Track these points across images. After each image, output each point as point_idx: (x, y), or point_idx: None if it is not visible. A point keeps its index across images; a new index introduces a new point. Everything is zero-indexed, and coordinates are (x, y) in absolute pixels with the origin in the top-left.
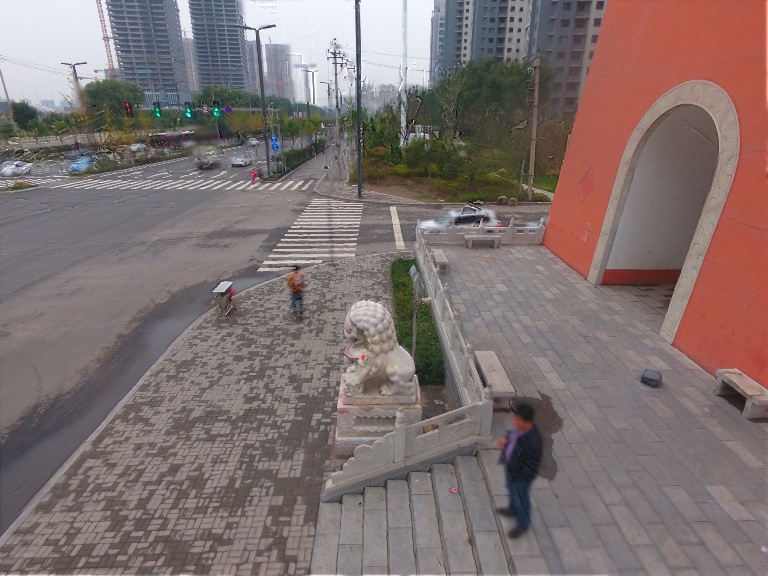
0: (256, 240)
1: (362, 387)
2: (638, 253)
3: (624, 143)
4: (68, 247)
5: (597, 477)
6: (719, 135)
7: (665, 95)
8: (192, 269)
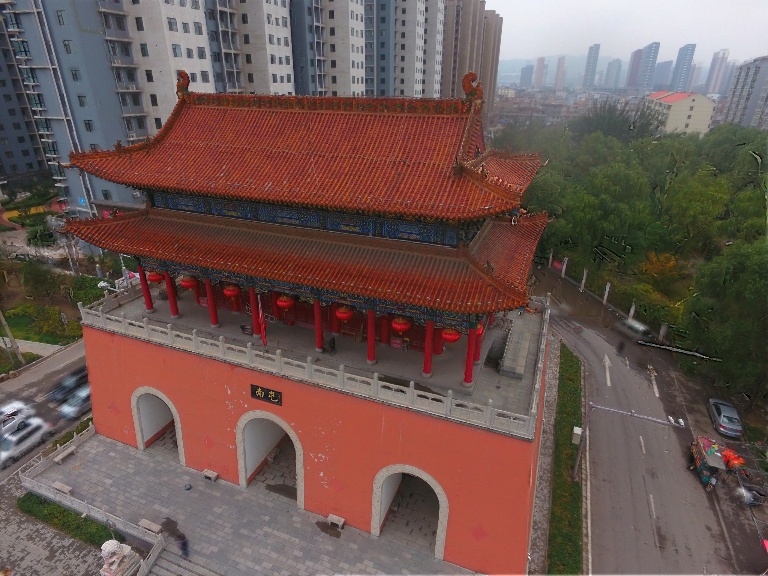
0: None
1: (118, 566)
2: (153, 429)
3: (129, 398)
4: None
5: (193, 529)
6: (169, 407)
7: (141, 388)
8: None
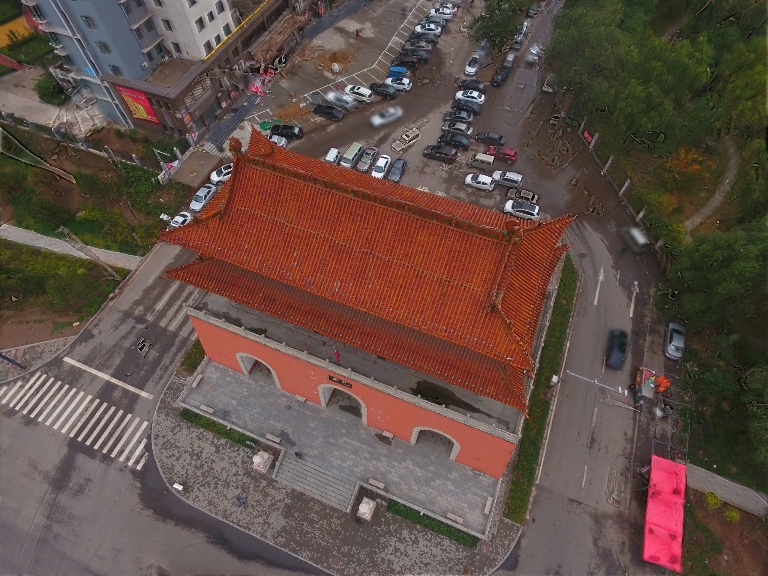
0: (88, 462)
1: (263, 465)
2: None
3: None
4: (26, 570)
5: (300, 438)
6: (267, 366)
7: None
8: (117, 499)
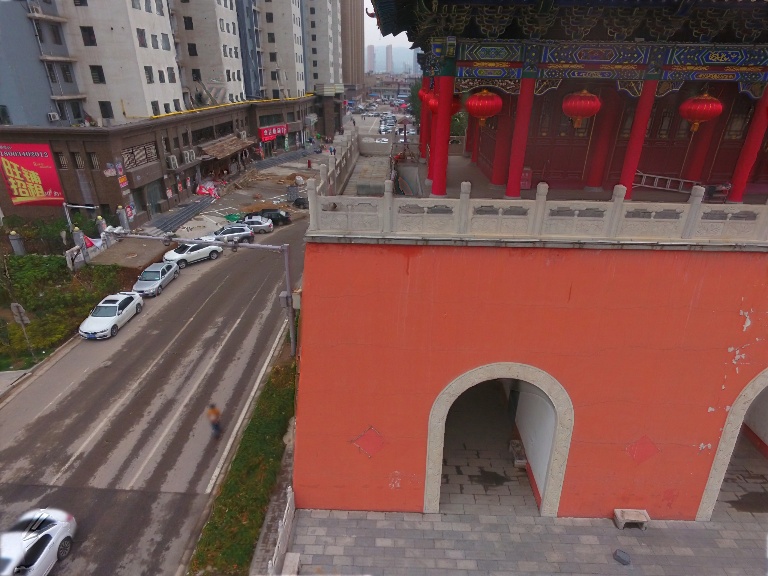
0: None
1: None
2: None
3: (425, 404)
4: None
5: None
6: (551, 398)
7: (475, 370)
8: None
